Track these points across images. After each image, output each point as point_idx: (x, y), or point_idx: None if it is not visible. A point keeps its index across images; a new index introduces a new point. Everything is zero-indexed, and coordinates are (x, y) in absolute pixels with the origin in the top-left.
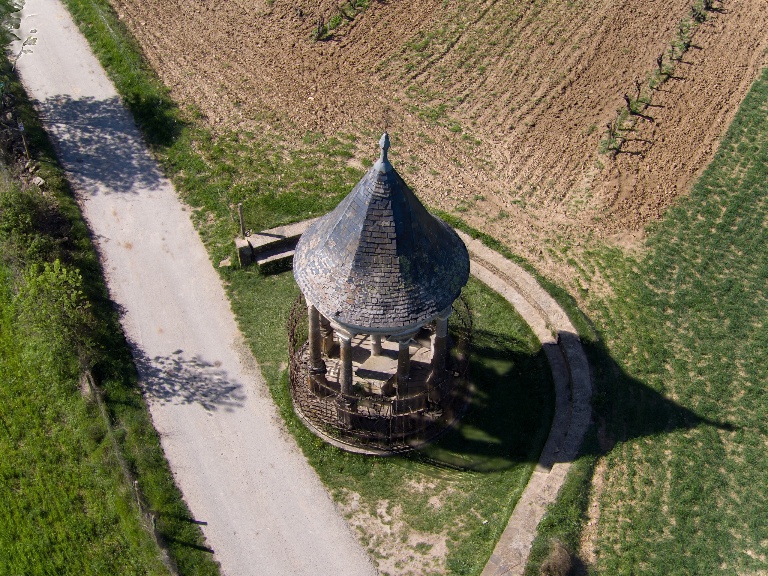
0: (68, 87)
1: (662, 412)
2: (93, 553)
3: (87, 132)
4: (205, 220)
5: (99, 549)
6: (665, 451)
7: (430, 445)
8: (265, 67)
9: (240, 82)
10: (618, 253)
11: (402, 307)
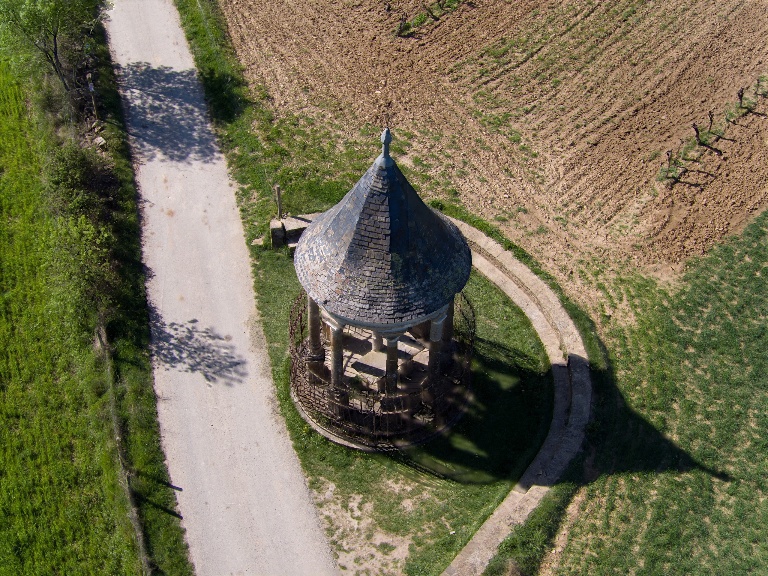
0: (150, 55)
1: (657, 451)
2: (70, 500)
3: (158, 100)
4: (248, 198)
5: (77, 497)
6: (651, 491)
7: (415, 448)
8: (341, 57)
9: (313, 68)
10: (651, 284)
11: (389, 304)
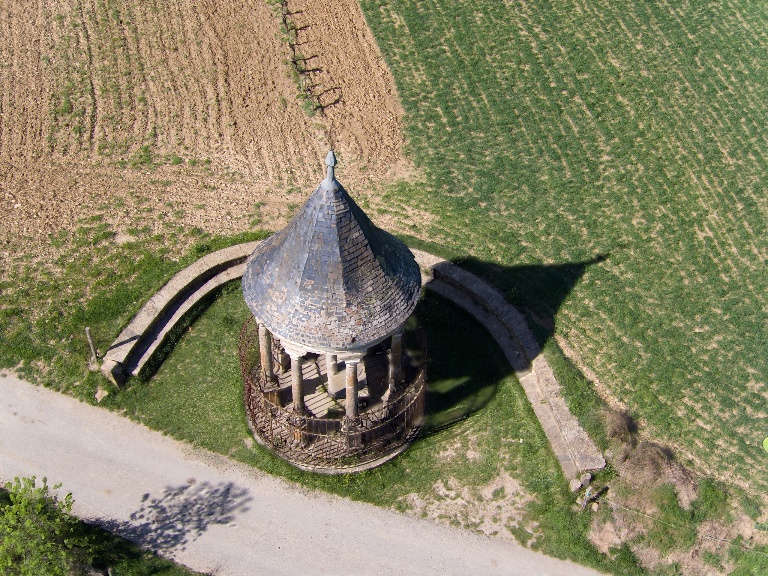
0: None
1: (556, 277)
2: None
3: None
4: (38, 371)
5: None
6: (584, 302)
7: (428, 416)
8: None
9: None
10: (405, 184)
11: (400, 300)
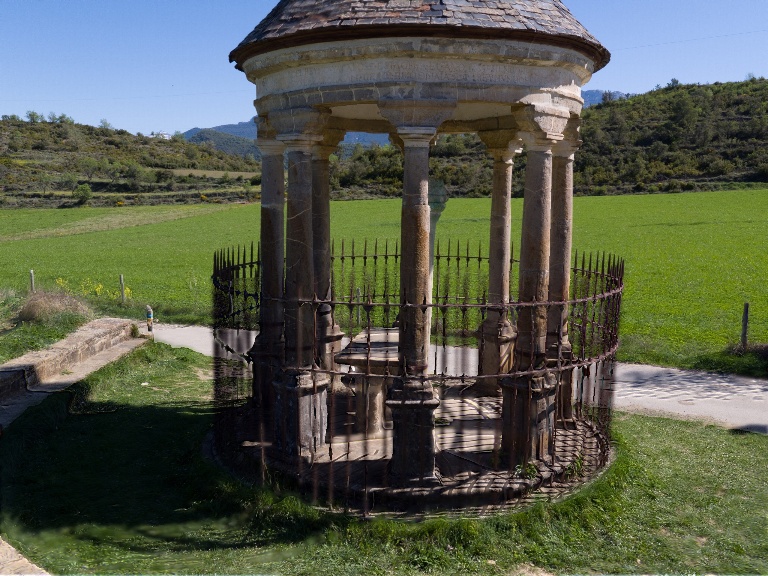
0: None
1: None
2: None
3: None
4: None
5: None
6: None
7: None
8: None
9: None
10: None
11: None
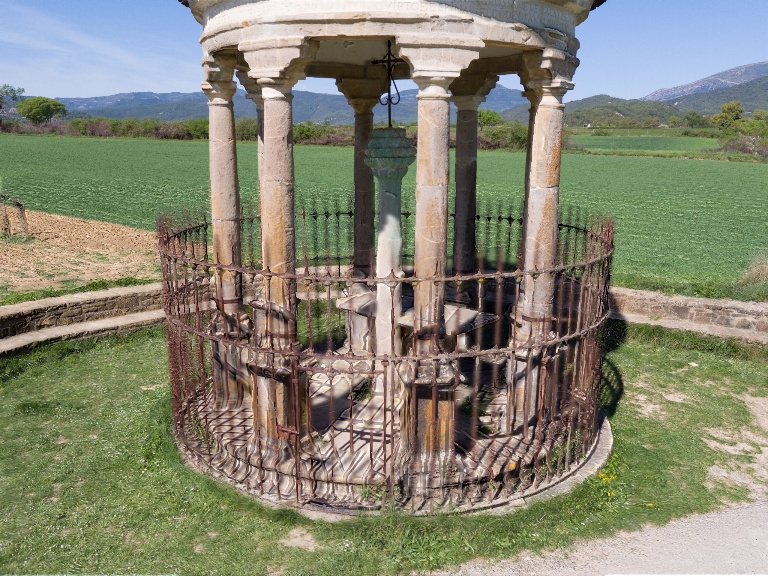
0: None
1: None
2: None
3: None
4: None
5: None
6: None
7: None
8: None
9: None
10: None
11: None
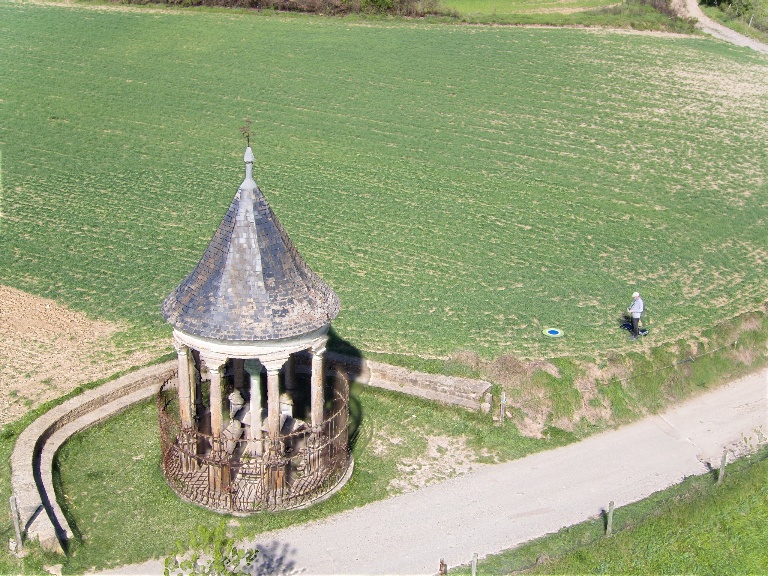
0: None
1: None
2: None
3: None
4: None
5: None
6: (349, 329)
7: None
8: None
9: None
10: (122, 333)
11: None
